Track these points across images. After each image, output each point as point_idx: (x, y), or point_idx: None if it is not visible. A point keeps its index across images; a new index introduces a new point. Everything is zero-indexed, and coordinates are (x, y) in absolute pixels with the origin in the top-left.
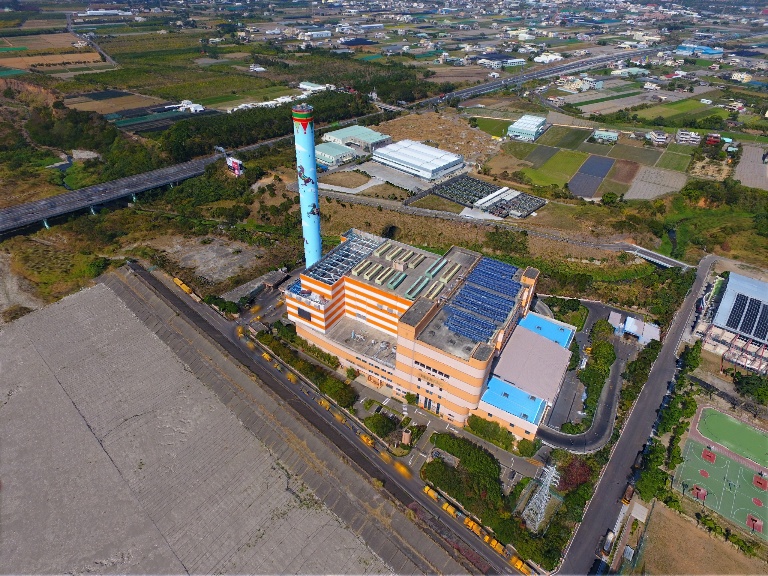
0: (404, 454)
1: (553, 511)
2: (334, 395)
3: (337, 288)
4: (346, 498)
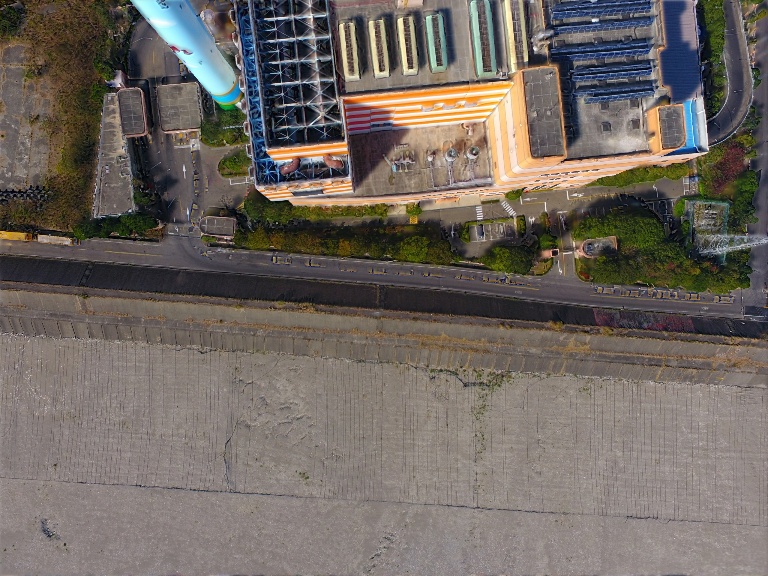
0: (549, 267)
1: (719, 221)
2: None
3: None
4: (532, 356)
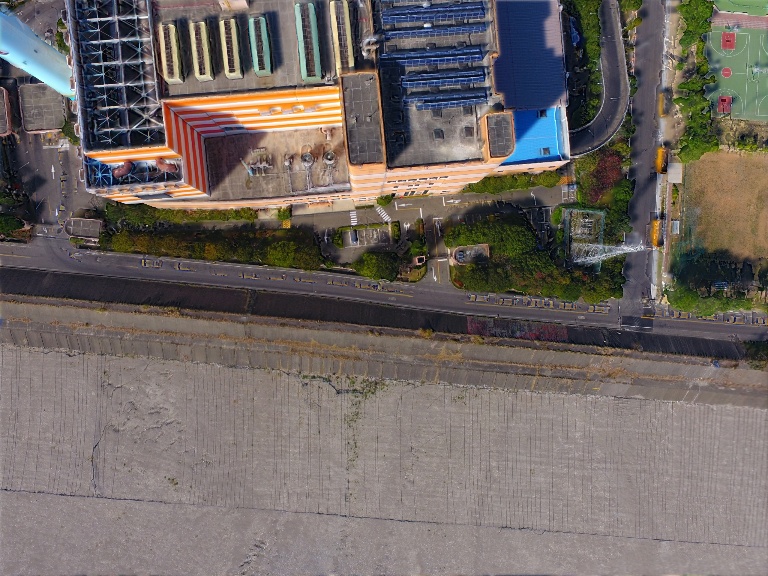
0: (423, 274)
1: (596, 230)
2: (294, 264)
3: (173, 134)
4: (404, 364)
